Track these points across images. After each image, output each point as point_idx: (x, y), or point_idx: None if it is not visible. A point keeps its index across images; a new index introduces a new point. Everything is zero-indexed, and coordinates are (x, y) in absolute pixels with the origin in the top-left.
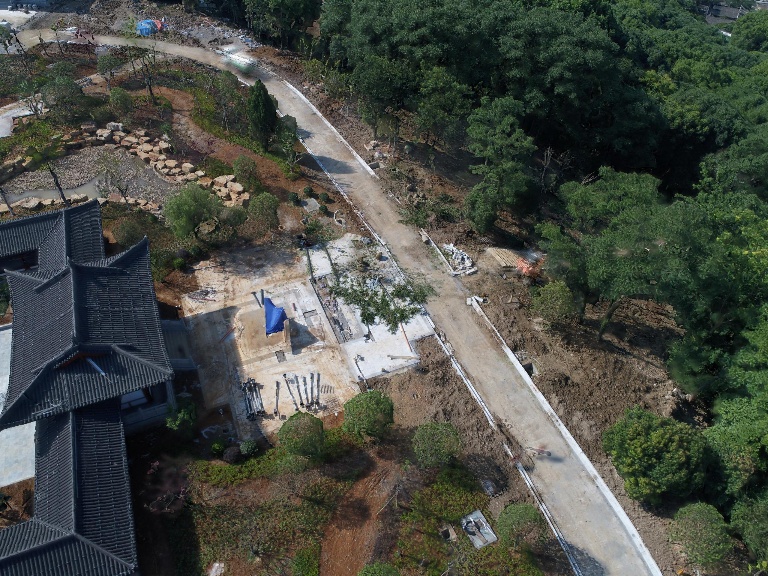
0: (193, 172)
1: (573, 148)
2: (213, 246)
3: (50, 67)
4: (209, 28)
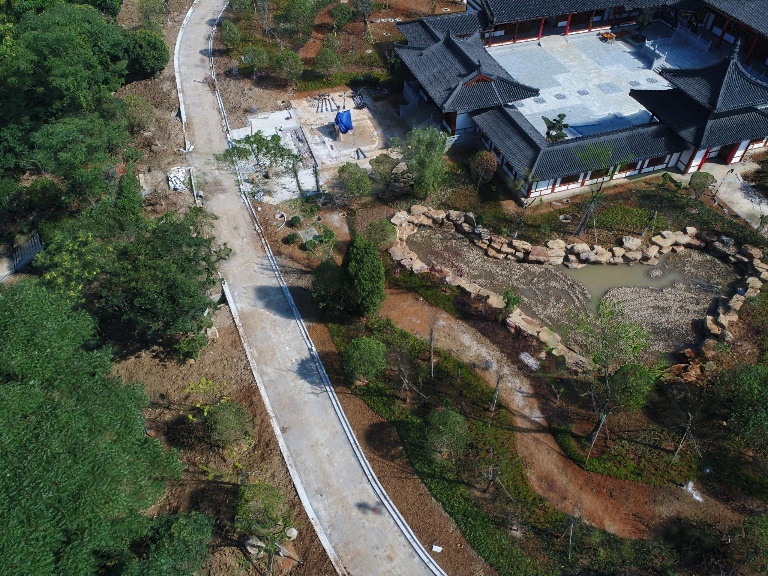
0: None
1: None
2: (409, 194)
3: None
4: None
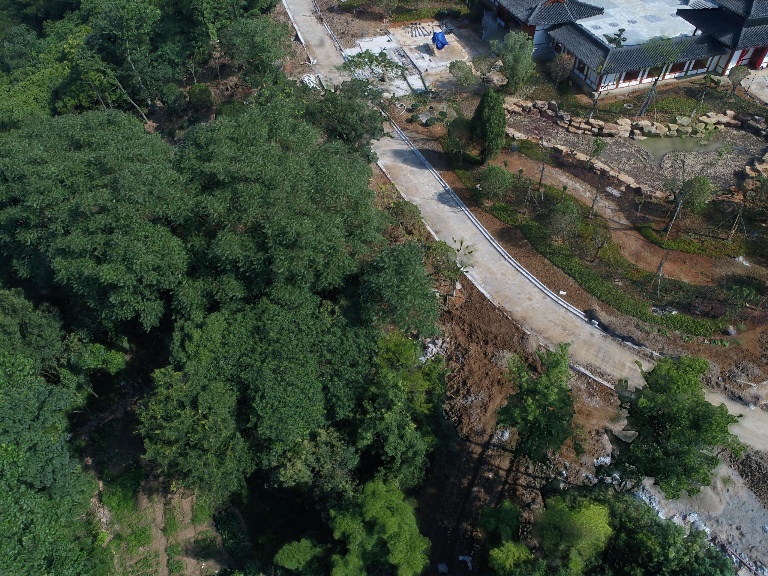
0: None
1: None
2: None
3: None
4: None
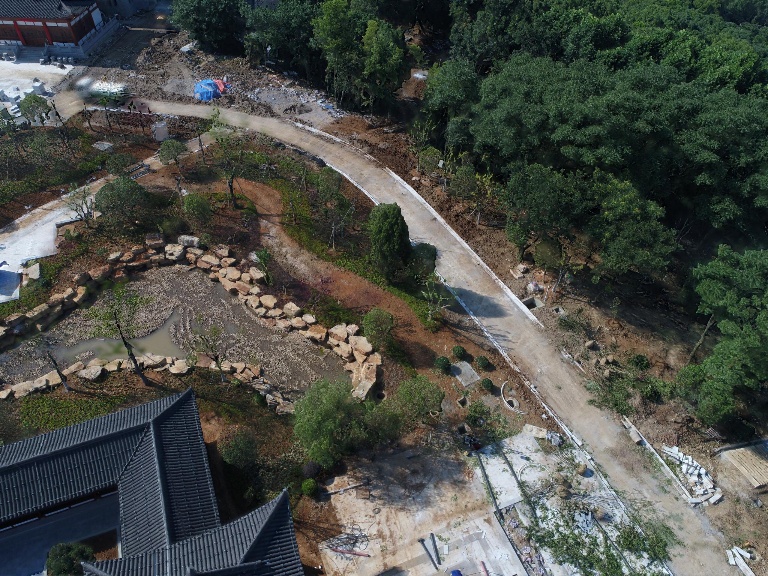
0: (299, 316)
1: (740, 253)
2: (348, 449)
3: (97, 146)
4: (280, 89)
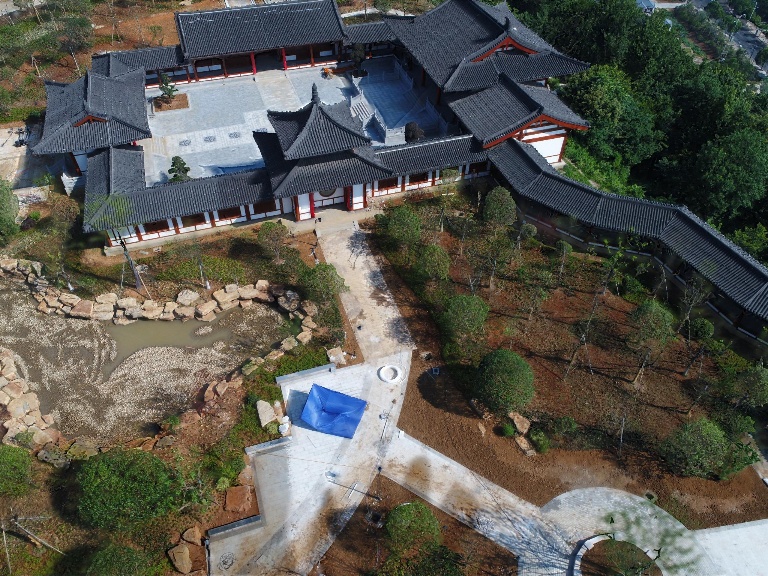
0: None
1: None
2: None
3: None
4: None
